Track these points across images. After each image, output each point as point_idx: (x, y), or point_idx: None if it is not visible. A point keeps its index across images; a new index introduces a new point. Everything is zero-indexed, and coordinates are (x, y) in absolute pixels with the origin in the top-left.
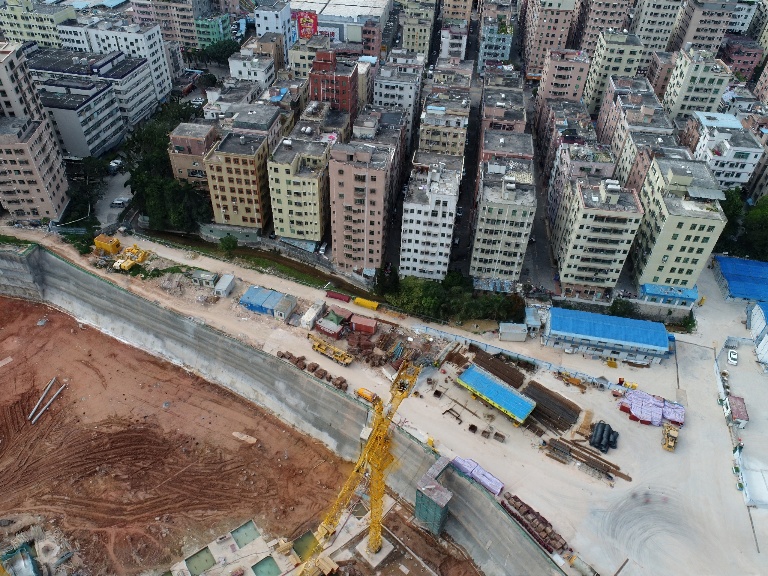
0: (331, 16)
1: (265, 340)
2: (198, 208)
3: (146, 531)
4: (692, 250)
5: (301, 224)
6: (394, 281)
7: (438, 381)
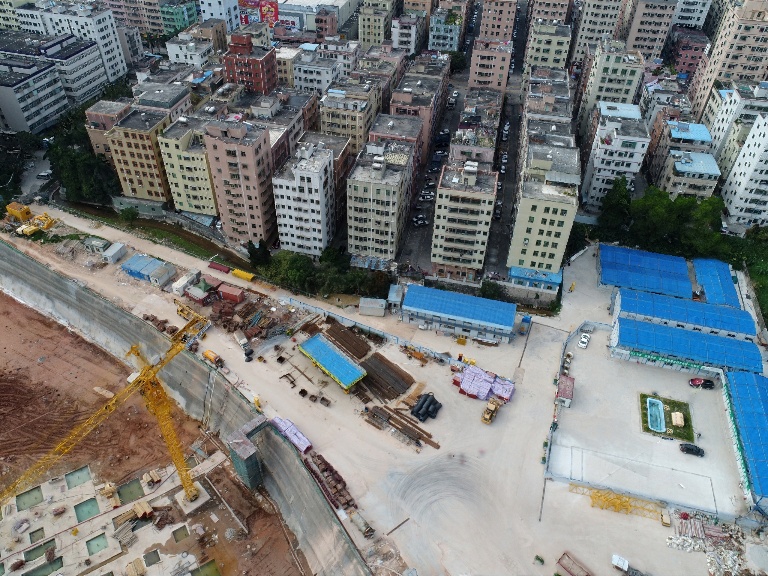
0: (291, 5)
1: (136, 304)
2: (108, 181)
3: None
4: (550, 234)
5: (197, 198)
6: (264, 253)
7: (286, 348)
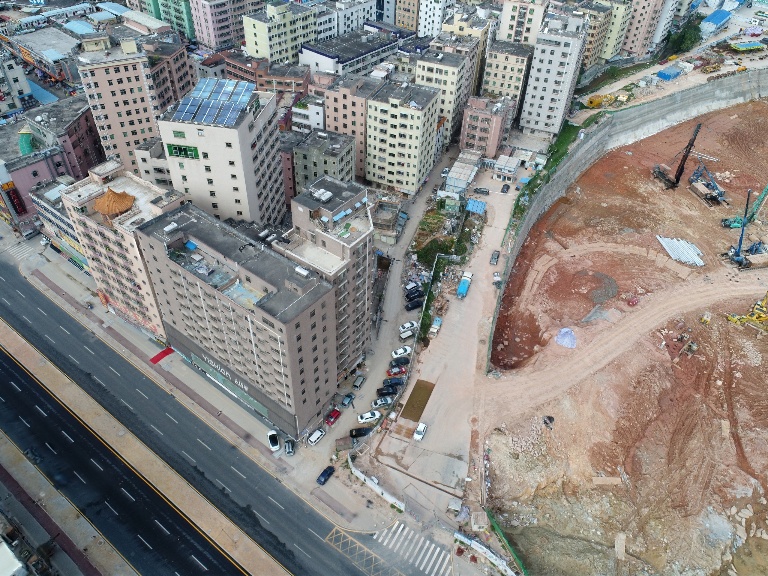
0: None
1: (696, 82)
2: None
3: None
4: None
5: None
6: None
7: None
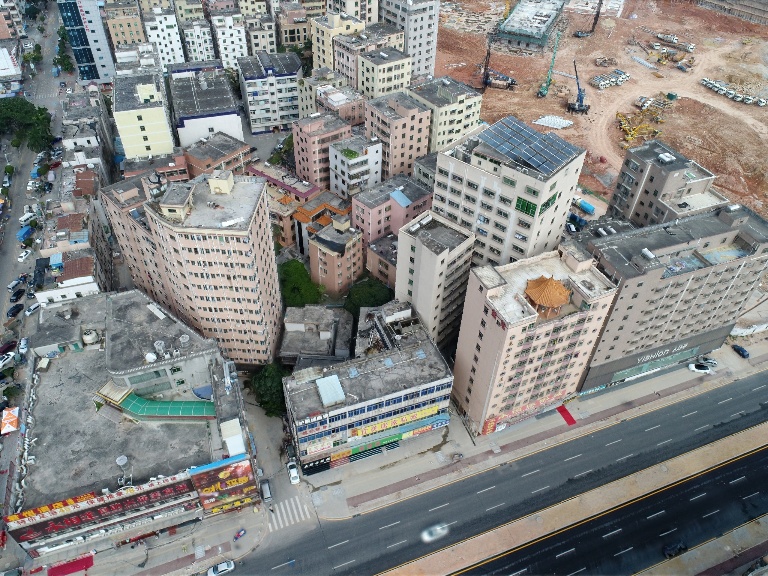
0: None
1: None
2: None
3: (467, 37)
4: None
5: None
6: None
7: None
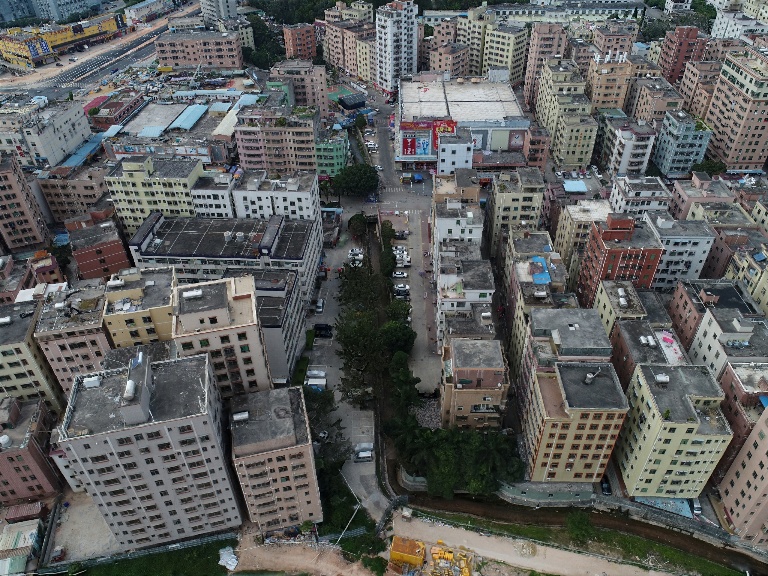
0: (474, 122)
1: None
2: (507, 466)
3: None
4: None
5: (678, 483)
6: None
7: None
